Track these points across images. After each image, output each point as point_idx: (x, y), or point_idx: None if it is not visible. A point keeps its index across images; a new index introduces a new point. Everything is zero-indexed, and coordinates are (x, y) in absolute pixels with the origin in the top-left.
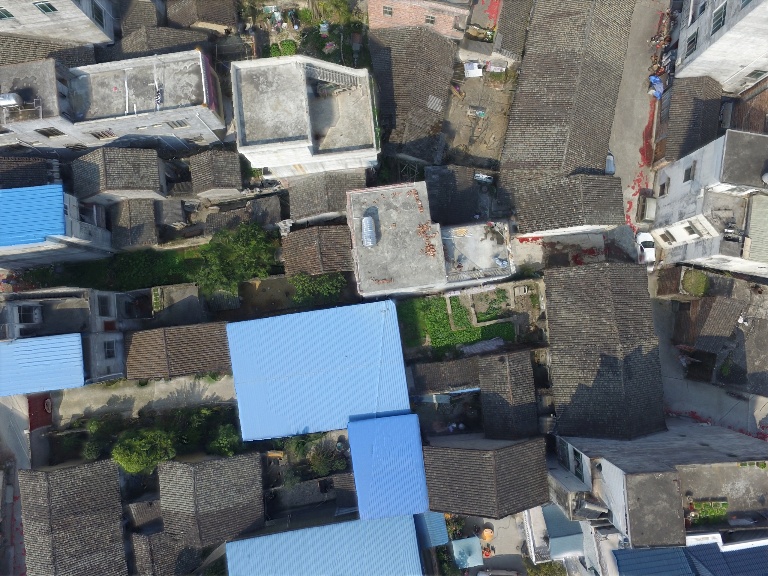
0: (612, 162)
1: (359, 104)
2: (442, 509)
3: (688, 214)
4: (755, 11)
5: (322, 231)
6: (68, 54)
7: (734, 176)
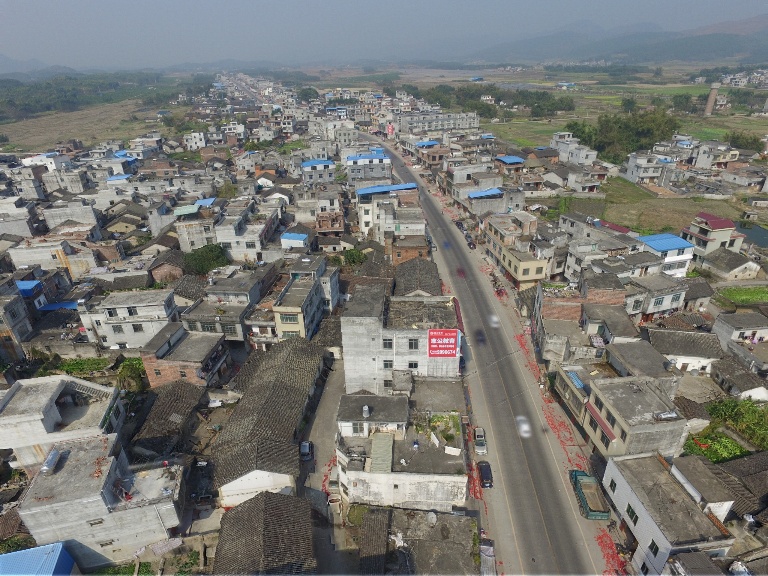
0: (307, 446)
1: (104, 407)
2: None
3: None
4: (344, 340)
5: None
6: None
7: (345, 417)
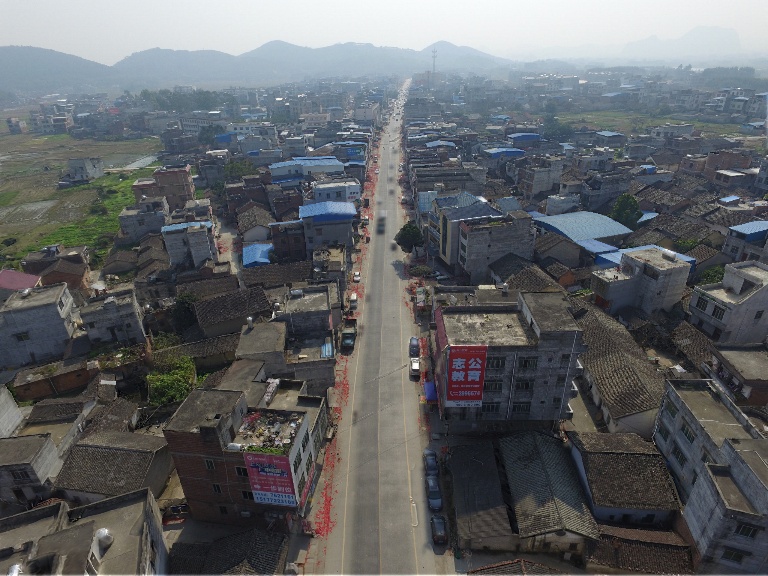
0: None
1: None
2: None
3: None
4: None
5: (689, 291)
6: None
7: None
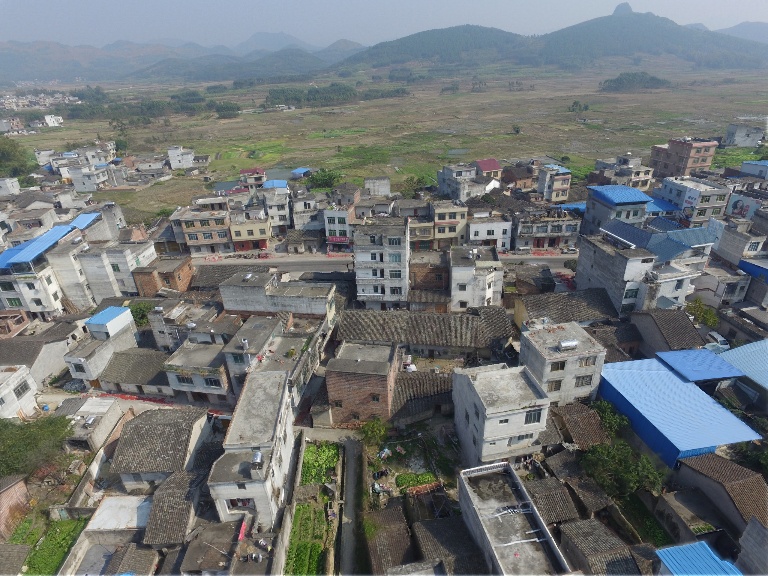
0: None
1: None
2: (700, 338)
3: (484, 285)
4: None
5: None
6: None
7: (472, 264)
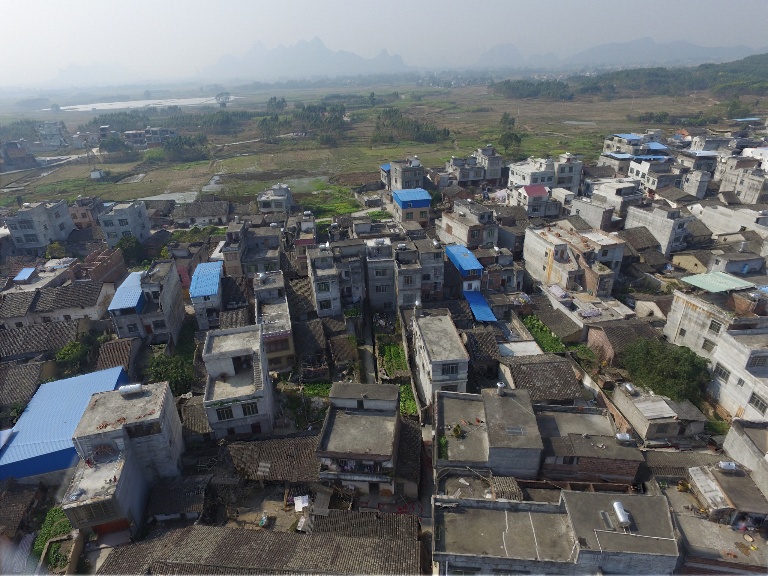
0: None
1: None
2: None
3: None
4: None
5: None
6: (308, 302)
7: None
